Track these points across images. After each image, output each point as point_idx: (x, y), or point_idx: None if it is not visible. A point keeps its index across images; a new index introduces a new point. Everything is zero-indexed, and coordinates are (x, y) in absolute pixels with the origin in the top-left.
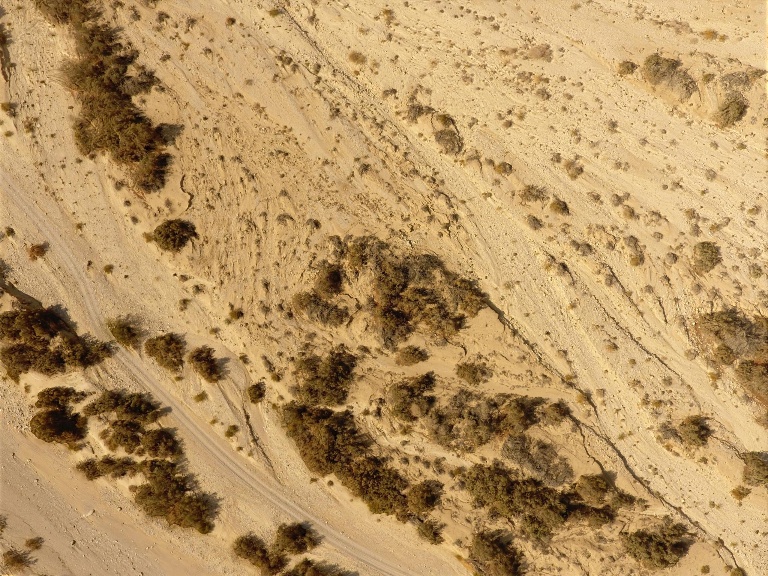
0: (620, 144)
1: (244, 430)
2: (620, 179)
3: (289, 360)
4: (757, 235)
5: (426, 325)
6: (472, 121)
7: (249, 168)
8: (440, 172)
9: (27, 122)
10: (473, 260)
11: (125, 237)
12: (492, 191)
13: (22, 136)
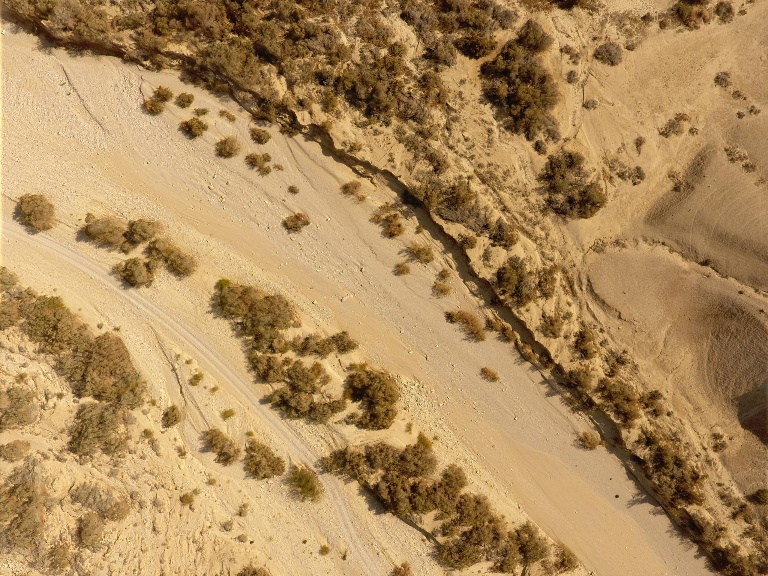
0: None
1: (184, 381)
2: None
3: (133, 452)
4: None
5: None
6: None
7: None
8: None
9: None
10: None
11: None
12: None
13: None
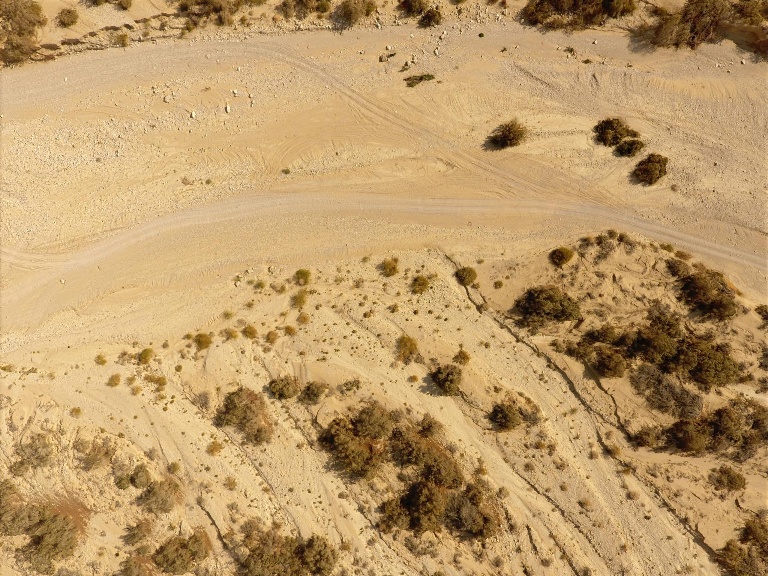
0: None
1: None
2: None
3: None
4: None
5: None
6: None
7: None
8: None
9: None
10: None
11: None
12: None
13: None
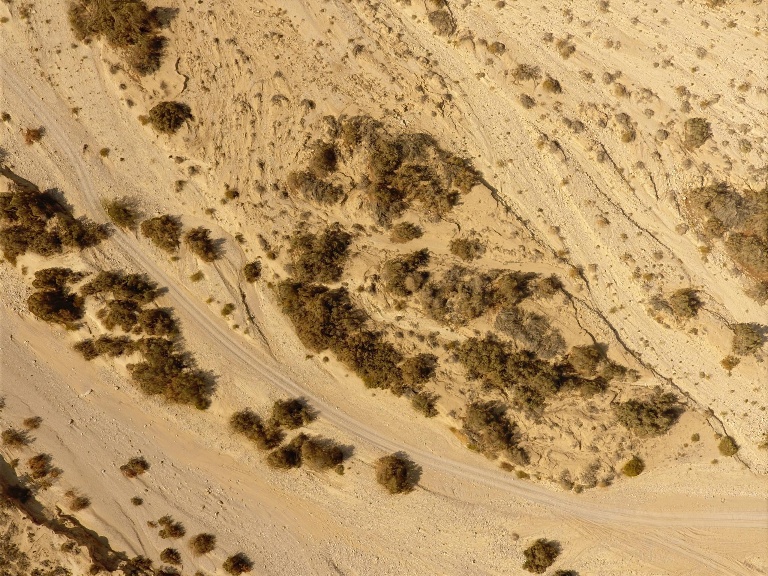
0: (612, 23)
1: (240, 308)
2: (612, 58)
3: (284, 238)
4: (747, 111)
5: (420, 202)
6: (465, 2)
7: (244, 50)
8: (434, 53)
9: (22, 8)
10: (466, 139)
11: (121, 121)
12: (485, 71)
13: (17, 22)
